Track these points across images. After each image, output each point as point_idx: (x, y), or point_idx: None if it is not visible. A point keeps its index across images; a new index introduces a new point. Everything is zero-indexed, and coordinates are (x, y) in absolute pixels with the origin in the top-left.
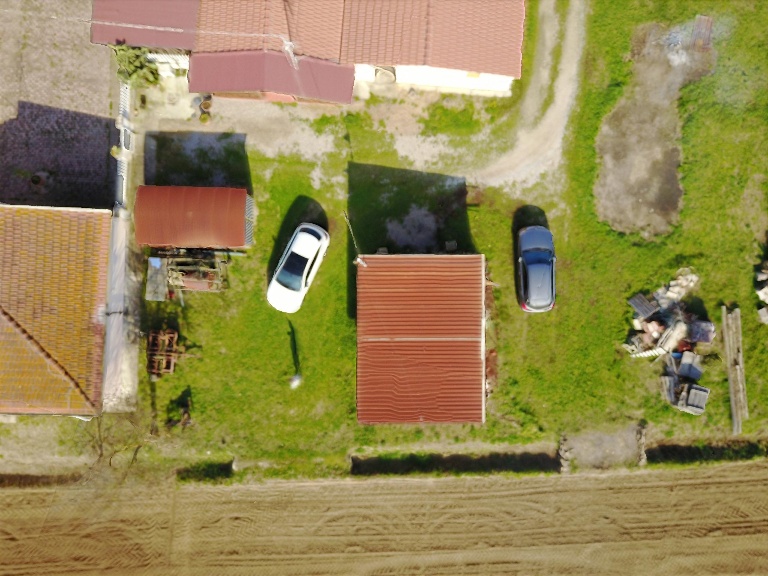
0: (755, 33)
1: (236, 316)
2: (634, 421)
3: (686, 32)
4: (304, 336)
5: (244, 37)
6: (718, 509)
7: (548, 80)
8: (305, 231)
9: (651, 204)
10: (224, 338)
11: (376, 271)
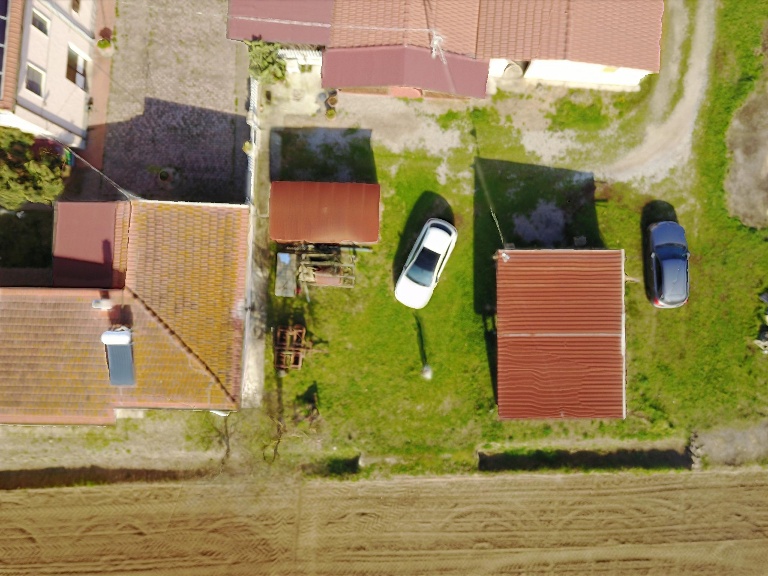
0: None
1: (362, 312)
2: (766, 418)
3: None
4: (431, 332)
5: (382, 32)
6: None
7: (677, 75)
8: (436, 227)
9: None
10: (350, 334)
11: (516, 266)
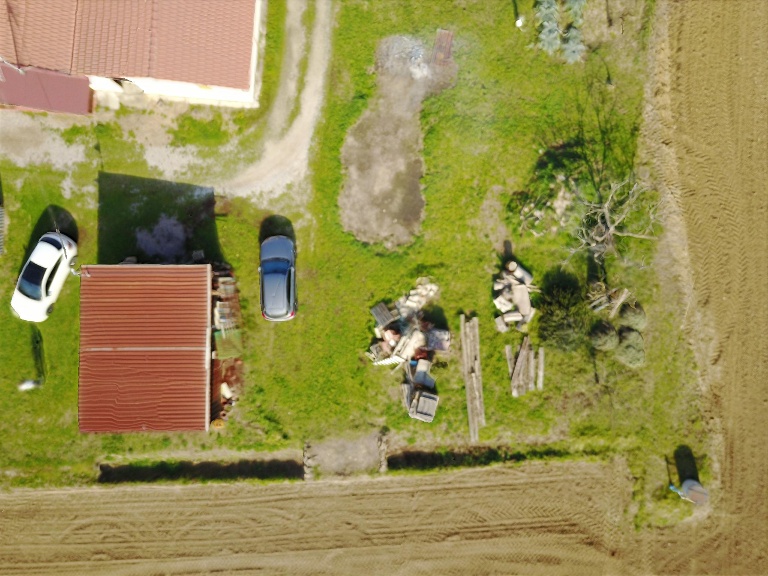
0: (494, 47)
1: None
2: (376, 428)
3: (428, 46)
4: (52, 345)
5: None
6: (457, 514)
7: (295, 92)
8: (46, 240)
9: (394, 214)
10: None
11: (100, 281)
